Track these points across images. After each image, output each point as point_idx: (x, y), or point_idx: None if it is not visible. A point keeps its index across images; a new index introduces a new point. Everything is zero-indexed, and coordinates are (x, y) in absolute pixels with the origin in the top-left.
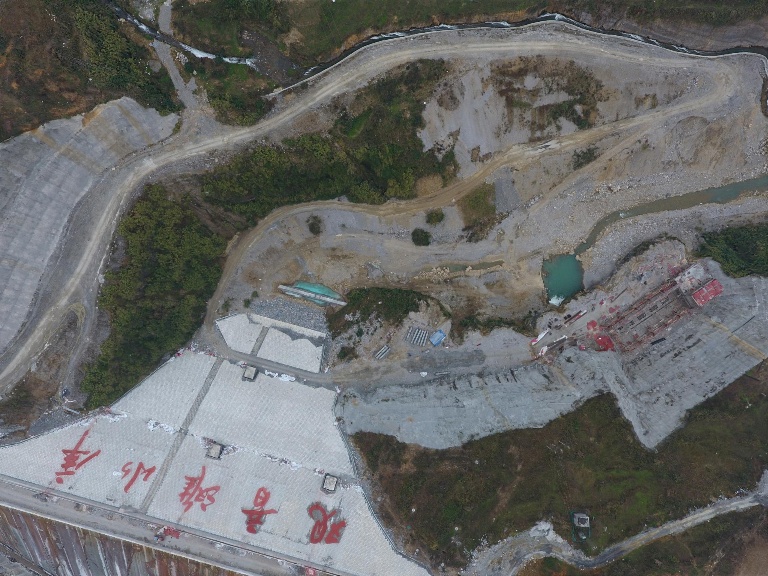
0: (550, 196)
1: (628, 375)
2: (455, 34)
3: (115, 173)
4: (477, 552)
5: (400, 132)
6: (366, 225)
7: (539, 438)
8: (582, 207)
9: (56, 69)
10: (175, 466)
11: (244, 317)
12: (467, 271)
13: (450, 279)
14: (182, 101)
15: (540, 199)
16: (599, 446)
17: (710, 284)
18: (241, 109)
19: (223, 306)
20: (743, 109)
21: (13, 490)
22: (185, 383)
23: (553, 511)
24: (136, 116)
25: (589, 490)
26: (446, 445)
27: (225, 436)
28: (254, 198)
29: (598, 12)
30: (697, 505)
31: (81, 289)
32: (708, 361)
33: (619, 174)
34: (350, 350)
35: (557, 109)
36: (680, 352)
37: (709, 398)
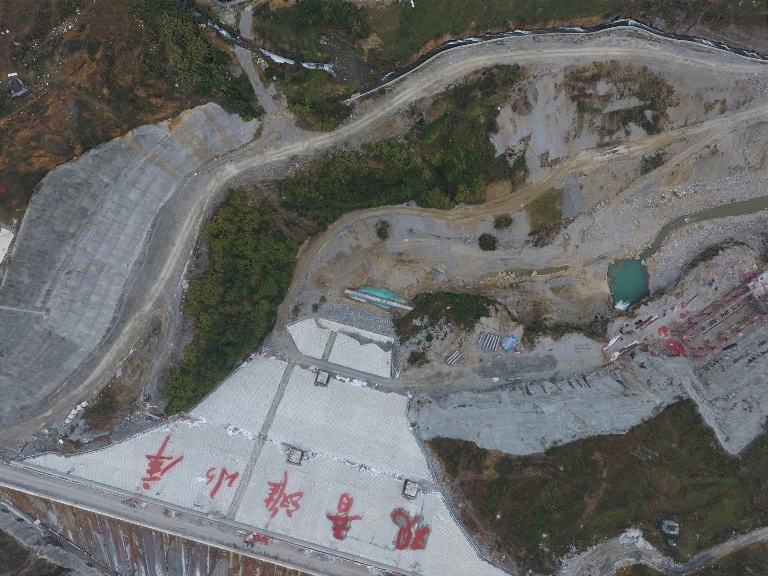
0: (616, 201)
1: (701, 381)
2: (530, 39)
3: (197, 178)
4: (566, 559)
5: (474, 137)
6: (434, 230)
7: (623, 444)
8: (648, 212)
9: (145, 75)
10: (257, 472)
11: (312, 322)
12: (533, 276)
13: (516, 284)
14: (262, 106)
15: (606, 204)
16: (682, 452)
17: None
18: (321, 114)
19: (293, 311)
20: None
21: (102, 496)
22: (260, 388)
23: (641, 518)
24: (220, 122)
25: (675, 497)
26: (528, 451)
27: (304, 441)
28: (327, 203)
29: (672, 18)
30: None
31: (165, 294)
32: None
33: (685, 179)
34: (420, 355)
35: (627, 114)
36: (754, 358)
37: None
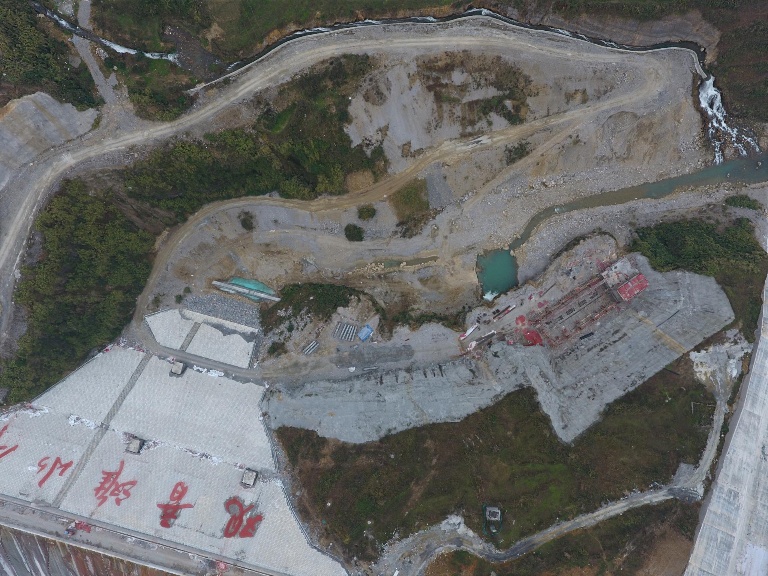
0: (484, 191)
1: (555, 370)
2: (380, 29)
3: (33, 168)
4: (388, 546)
5: (326, 127)
6: (298, 221)
7: (455, 432)
8: (516, 202)
9: None
10: (93, 461)
11: (176, 313)
12: (401, 267)
13: (384, 275)
14: (102, 96)
15: (474, 194)
16: (516, 440)
17: (635, 279)
18: (161, 104)
19: (153, 302)
20: (673, 104)
21: None
22: (111, 378)
23: (465, 505)
24: (52, 111)
25: (503, 484)
26: (364, 439)
27: (146, 431)
28: (181, 194)
29: (524, 7)
30: (610, 498)
31: None
32: (632, 355)
33: (553, 169)
34: (280, 345)
35: (487, 104)
36: (606, 347)
37: (629, 392)
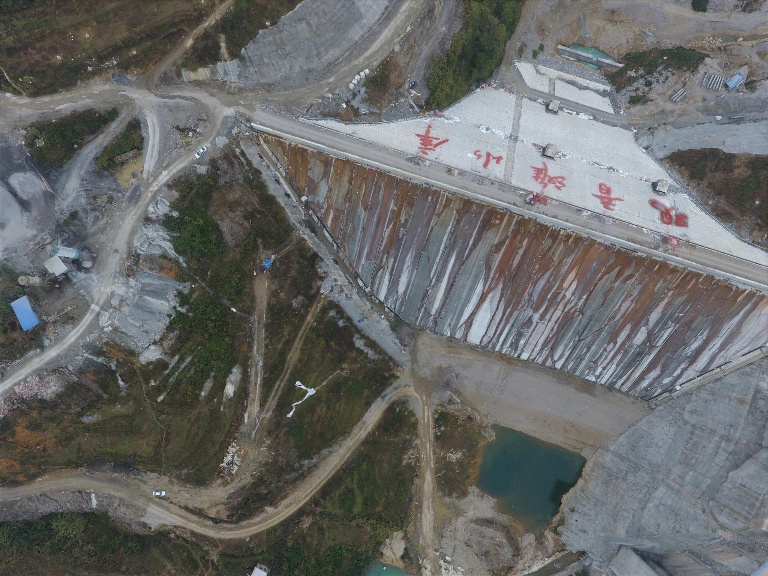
0: None
1: None
2: None
3: None
4: None
5: None
6: None
7: None
8: None
9: None
10: (519, 158)
11: (532, 67)
12: (739, 41)
13: (724, 47)
14: None
15: None
16: None
17: None
18: None
19: (520, 49)
20: None
21: (387, 153)
22: (498, 107)
23: None
24: None
25: None
26: None
27: None
28: None
29: None
30: None
31: None
32: None
33: None
34: (642, 96)
35: None
36: None
37: None
